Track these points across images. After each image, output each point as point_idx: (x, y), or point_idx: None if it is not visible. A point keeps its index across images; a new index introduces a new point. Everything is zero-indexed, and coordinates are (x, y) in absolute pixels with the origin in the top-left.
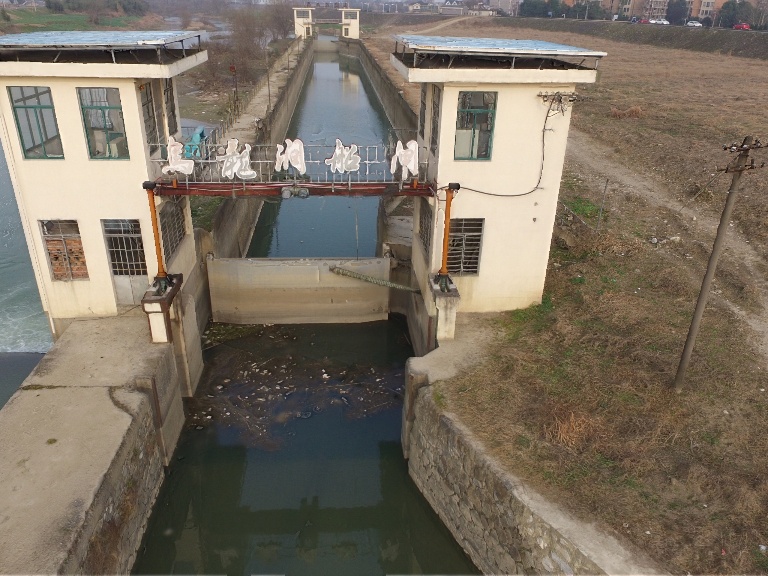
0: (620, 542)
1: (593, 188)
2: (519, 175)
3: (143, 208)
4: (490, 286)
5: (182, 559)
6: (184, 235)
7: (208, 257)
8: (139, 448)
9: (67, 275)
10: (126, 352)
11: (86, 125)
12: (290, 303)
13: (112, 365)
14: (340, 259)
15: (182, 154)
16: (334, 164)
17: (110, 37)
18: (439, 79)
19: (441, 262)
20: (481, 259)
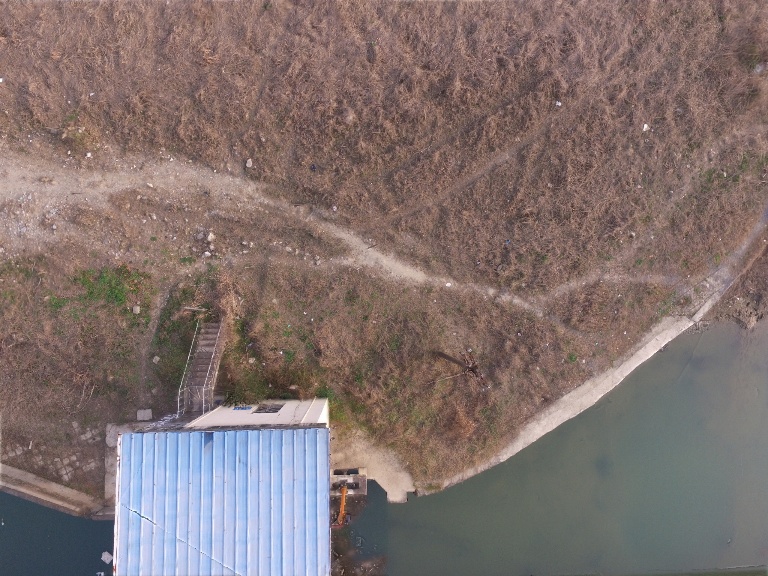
0: (530, 423)
1: (32, 246)
2: None
3: None
4: None
5: None
6: None
7: None
8: None
9: None
10: None
11: None
12: None
13: None
14: None
15: None
16: None
17: None
18: None
19: None
20: None
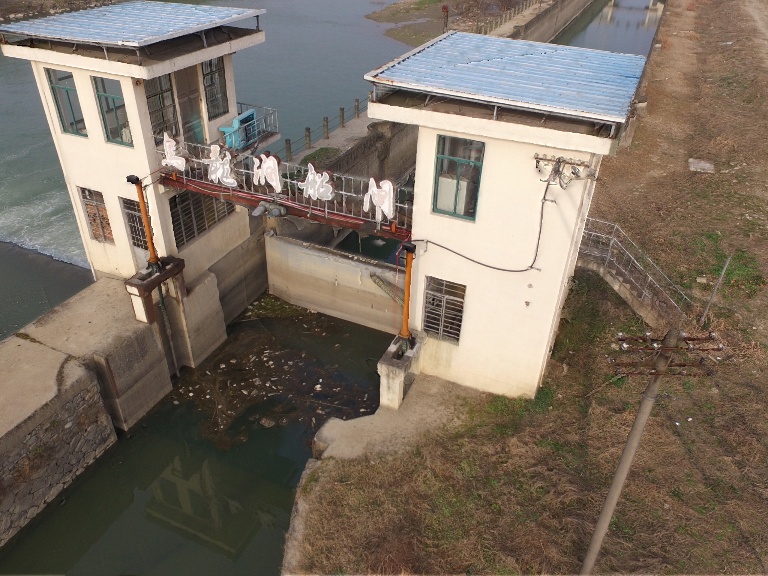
0: None
1: None
2: (510, 247)
3: (148, 194)
4: (472, 360)
5: (199, 492)
6: (232, 212)
7: (268, 233)
8: (66, 419)
9: (102, 236)
10: (110, 323)
11: (103, 110)
12: (333, 296)
13: (89, 333)
14: (388, 266)
15: (178, 150)
16: (307, 189)
17: (139, 23)
18: (402, 119)
19: (417, 318)
20: (462, 328)
